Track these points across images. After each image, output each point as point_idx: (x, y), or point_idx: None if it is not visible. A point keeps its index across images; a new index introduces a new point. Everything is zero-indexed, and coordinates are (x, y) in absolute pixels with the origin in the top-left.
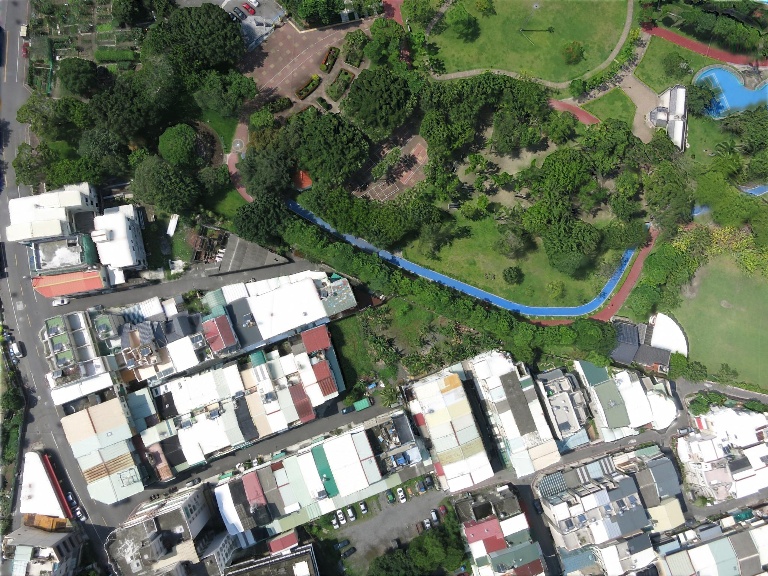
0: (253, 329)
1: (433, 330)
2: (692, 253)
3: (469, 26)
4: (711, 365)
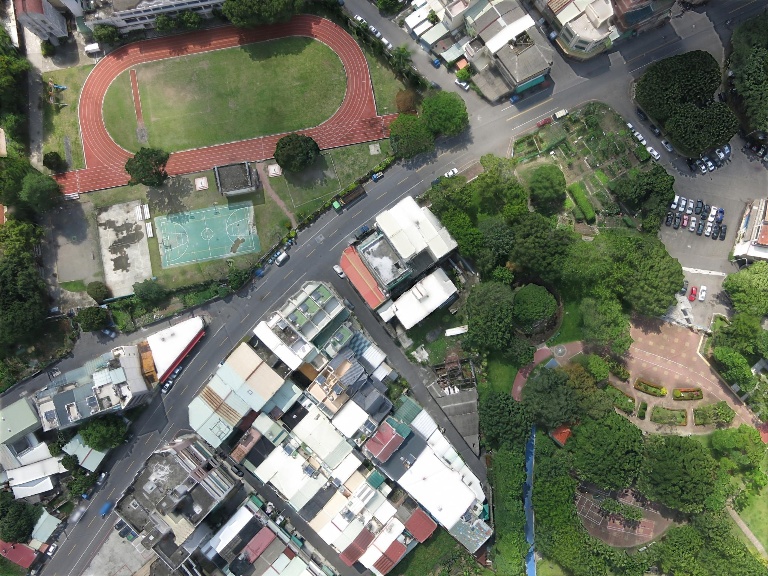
0: (403, 468)
1: None
2: None
3: None
4: None
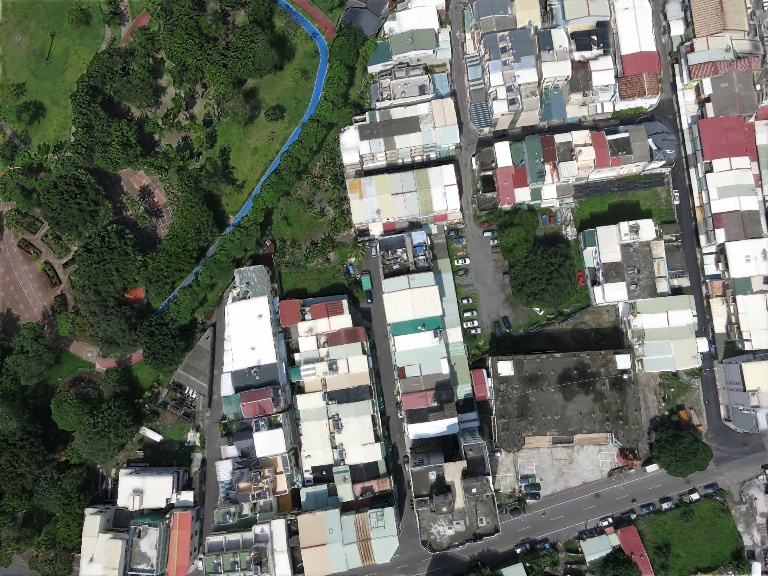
0: (263, 370)
1: (312, 201)
2: None
3: (27, 108)
4: None
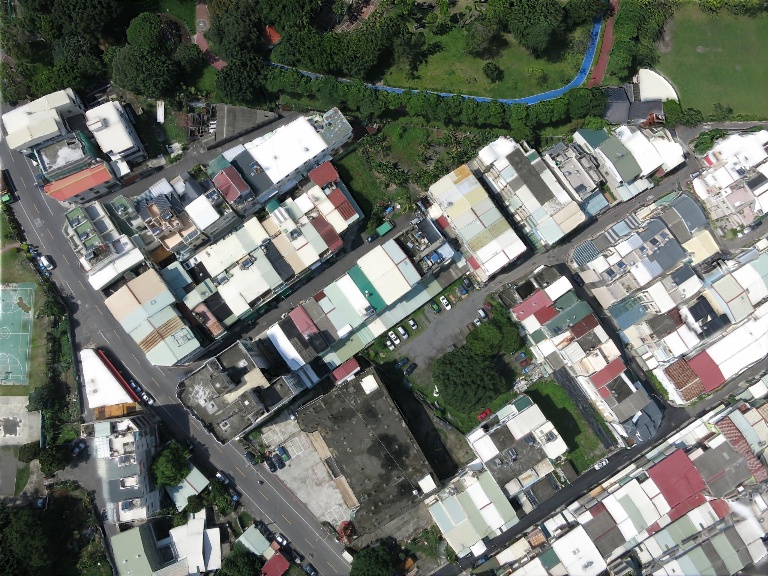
0: (262, 175)
1: (432, 145)
2: (655, 4)
3: None
4: (704, 108)
